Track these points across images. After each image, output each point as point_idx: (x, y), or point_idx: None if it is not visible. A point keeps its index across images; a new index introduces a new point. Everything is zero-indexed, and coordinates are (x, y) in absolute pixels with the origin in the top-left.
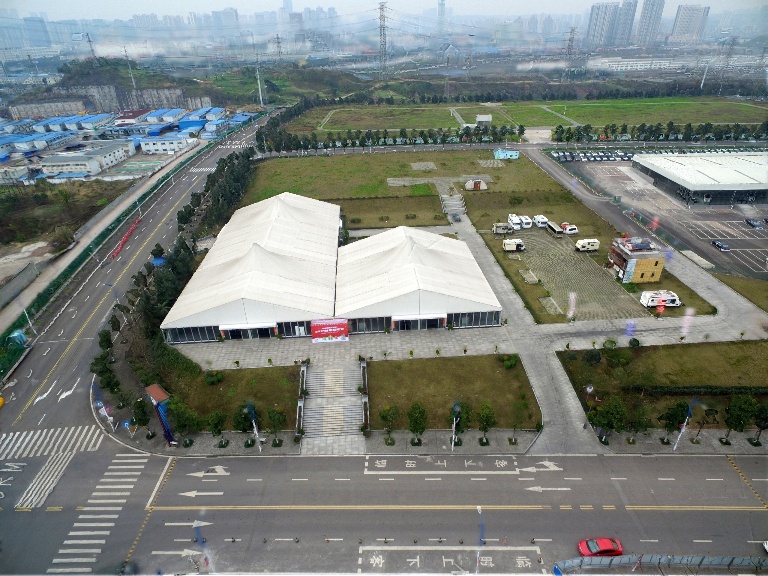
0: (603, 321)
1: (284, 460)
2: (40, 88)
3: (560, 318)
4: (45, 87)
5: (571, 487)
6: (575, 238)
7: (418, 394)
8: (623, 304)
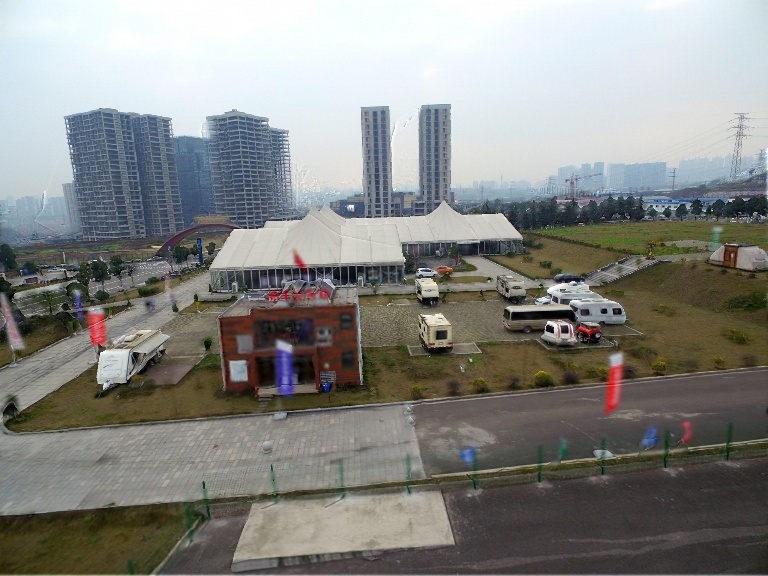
0: (154, 328)
1: (158, 277)
2: (744, 179)
3: (193, 310)
4: (748, 178)
5: (2, 317)
6: (528, 347)
7: (160, 283)
8: (179, 344)
